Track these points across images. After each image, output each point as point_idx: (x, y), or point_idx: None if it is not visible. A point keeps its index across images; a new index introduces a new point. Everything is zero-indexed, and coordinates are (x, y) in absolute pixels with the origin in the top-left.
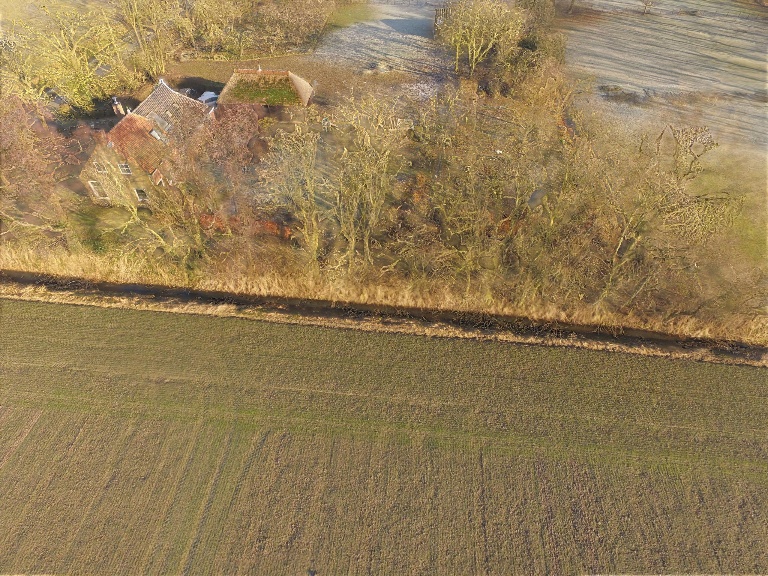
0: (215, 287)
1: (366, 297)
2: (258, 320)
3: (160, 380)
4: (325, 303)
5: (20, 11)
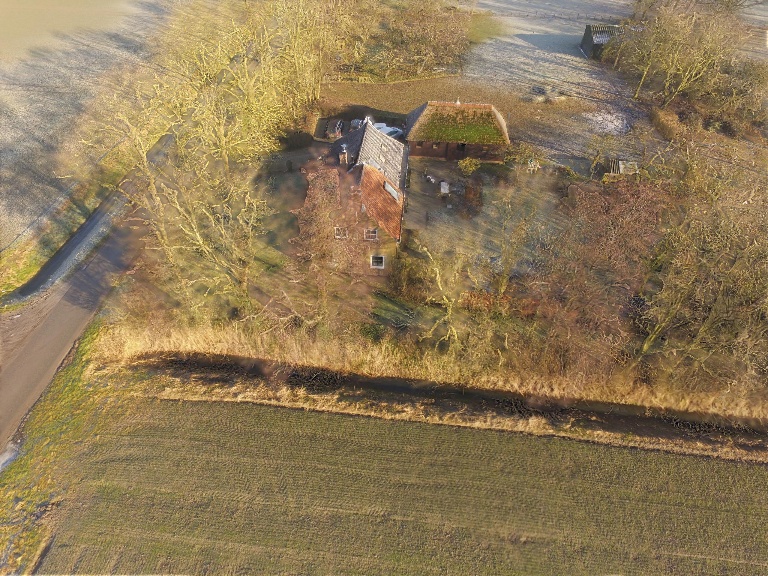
0: (494, 385)
1: (687, 403)
2: (585, 441)
3: (514, 538)
4: (636, 409)
5: (123, 22)
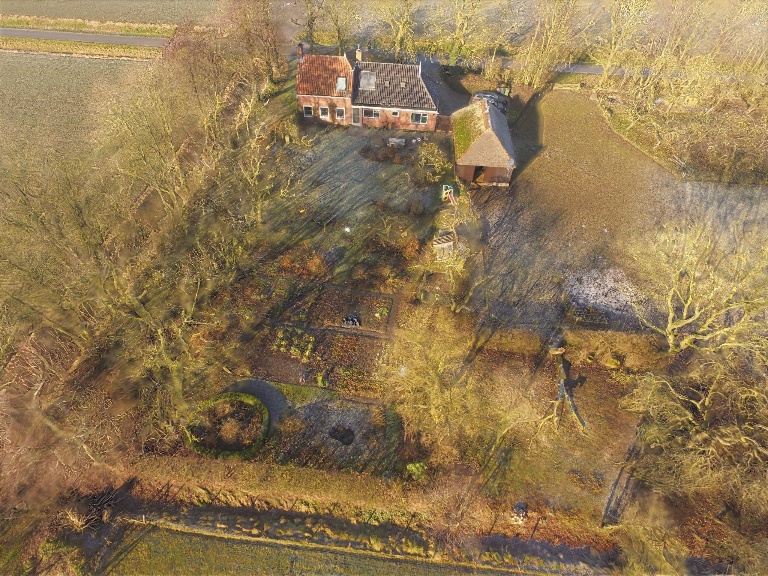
0: None
1: None
2: None
3: None
4: None
5: None
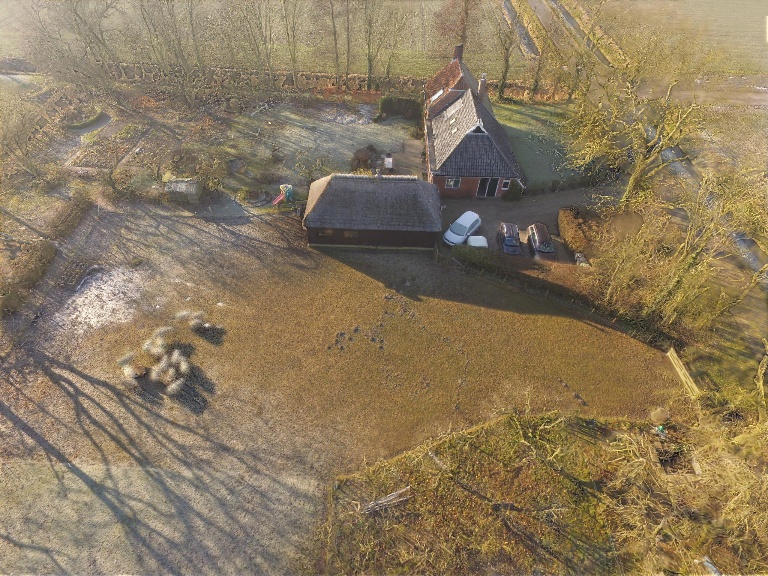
0: None
1: None
2: None
3: None
4: None
5: None
